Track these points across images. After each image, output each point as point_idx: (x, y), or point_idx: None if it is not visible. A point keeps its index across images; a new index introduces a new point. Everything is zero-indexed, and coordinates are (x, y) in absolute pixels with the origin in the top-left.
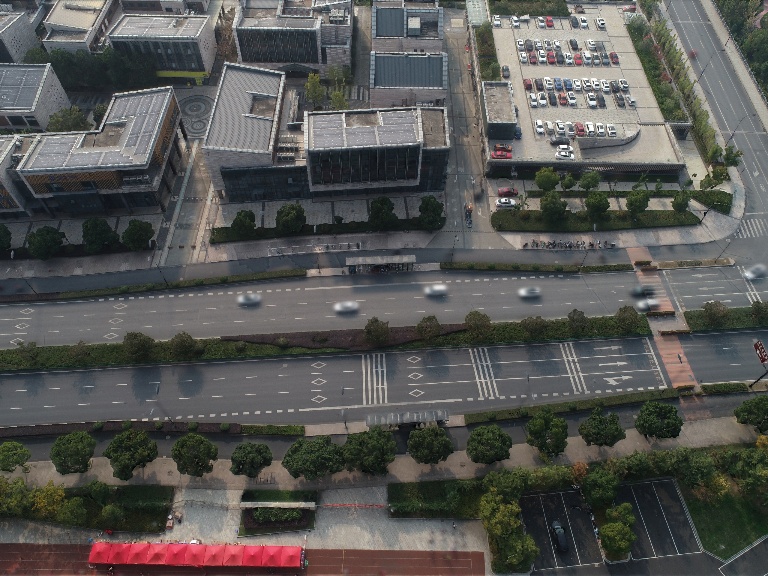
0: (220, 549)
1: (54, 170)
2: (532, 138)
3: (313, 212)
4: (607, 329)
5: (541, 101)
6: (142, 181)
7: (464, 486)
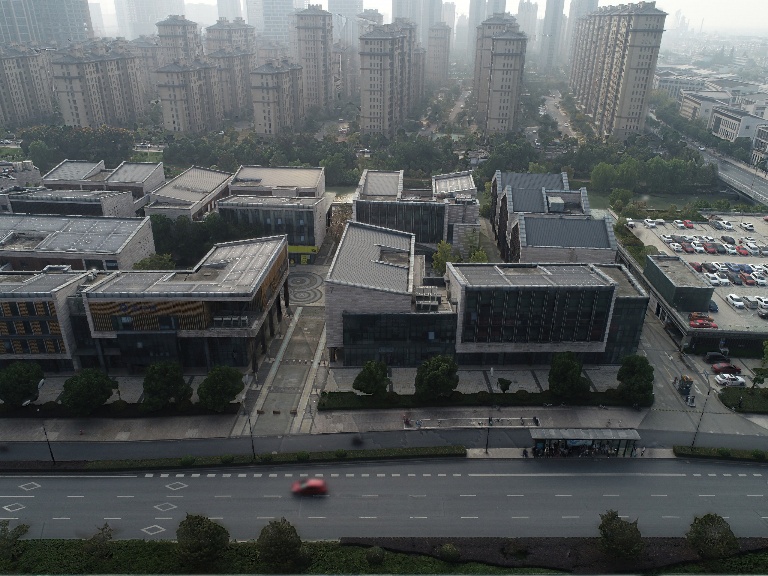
0: None
1: (130, 295)
2: (732, 312)
3: (460, 381)
4: None
5: (722, 280)
6: (238, 323)
7: None
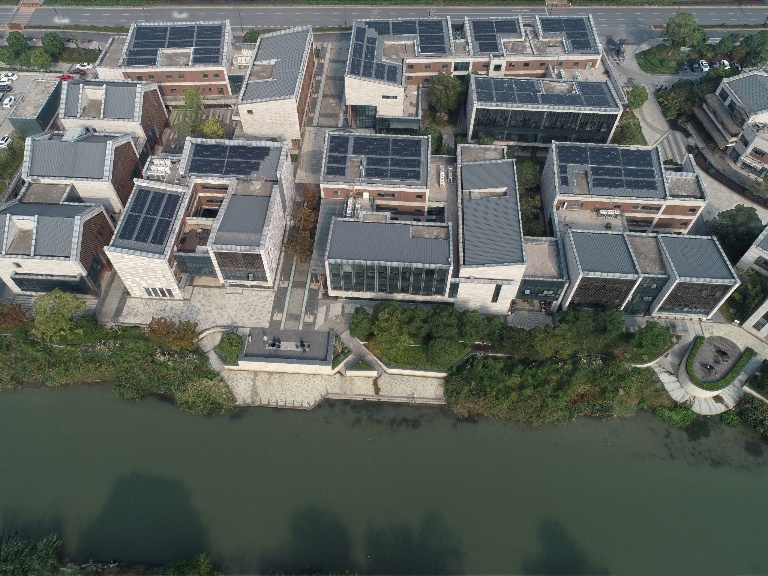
0: None
1: (423, 20)
2: None
3: None
4: None
5: None
6: None
7: None
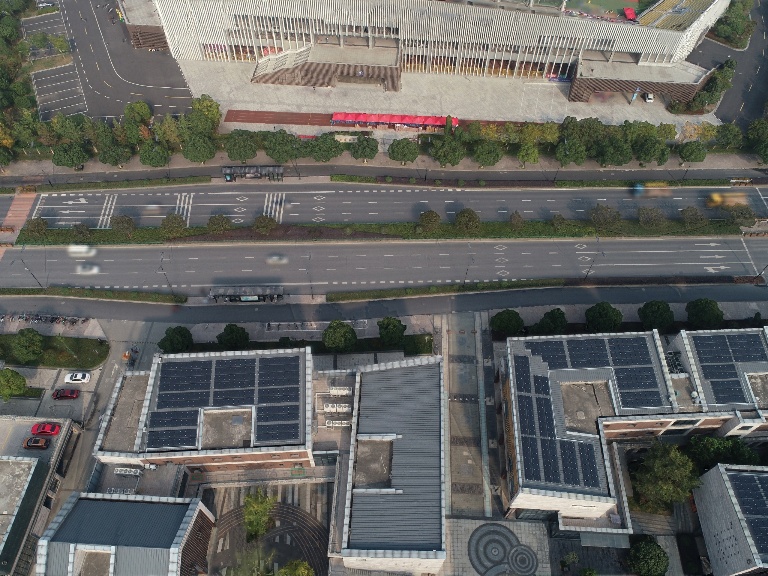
0: (381, 119)
1: None
2: None
3: None
4: (59, 233)
5: None
6: None
7: (225, 139)
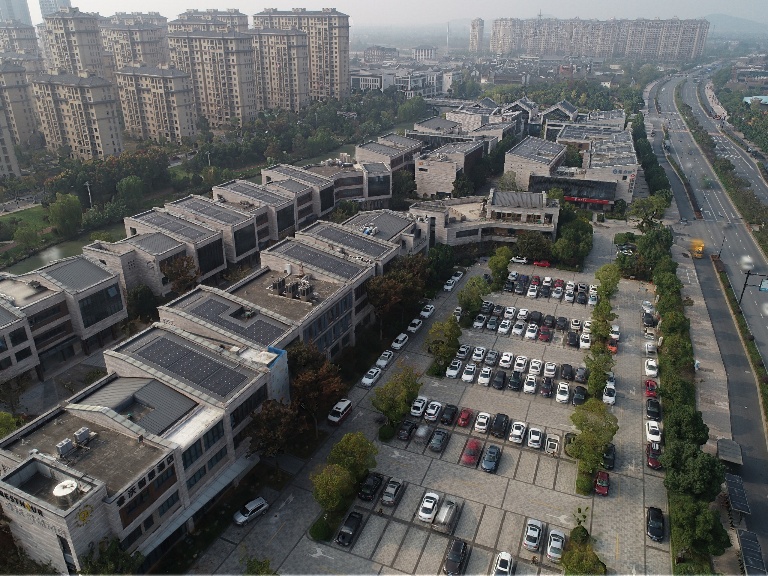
0: None
1: None
2: None
3: None
4: None
5: None
6: None
7: None
